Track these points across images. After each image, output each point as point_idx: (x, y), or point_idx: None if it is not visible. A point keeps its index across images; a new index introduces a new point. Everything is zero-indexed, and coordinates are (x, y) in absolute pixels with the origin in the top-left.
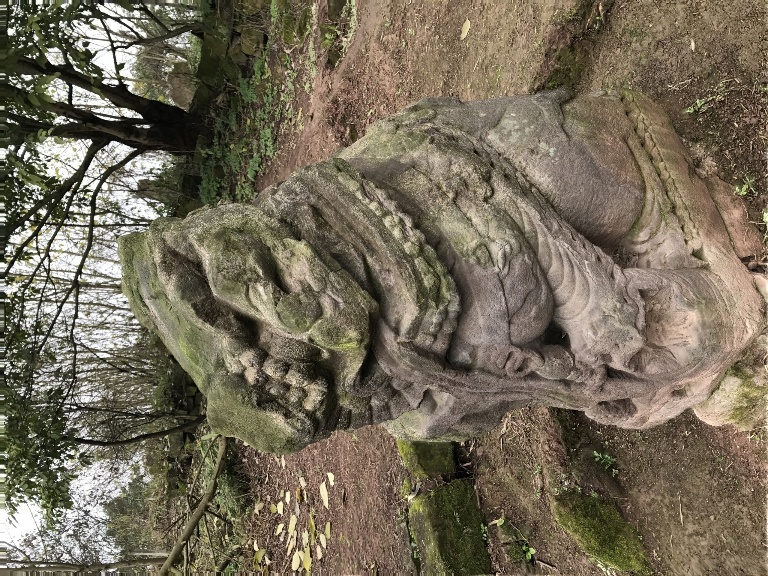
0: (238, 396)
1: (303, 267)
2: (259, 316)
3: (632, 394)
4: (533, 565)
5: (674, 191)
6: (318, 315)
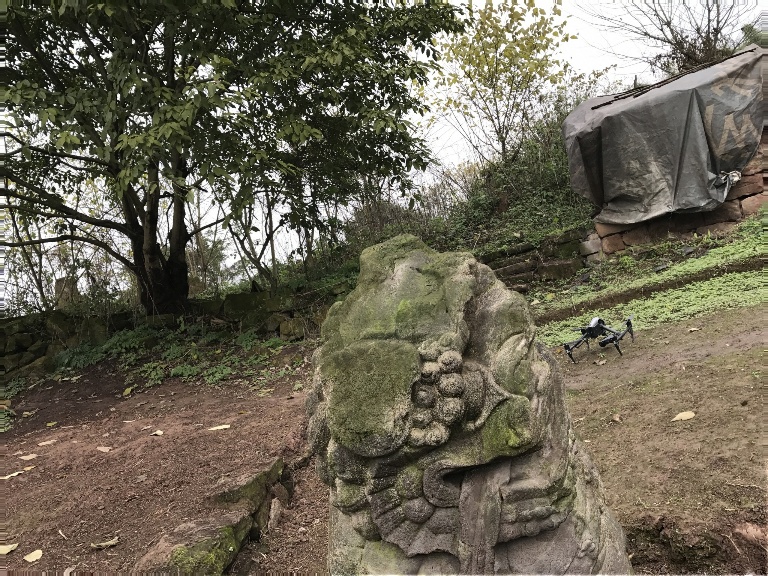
0: (414, 363)
1: (544, 371)
2: (491, 353)
3: None
4: None
5: None
6: (529, 397)
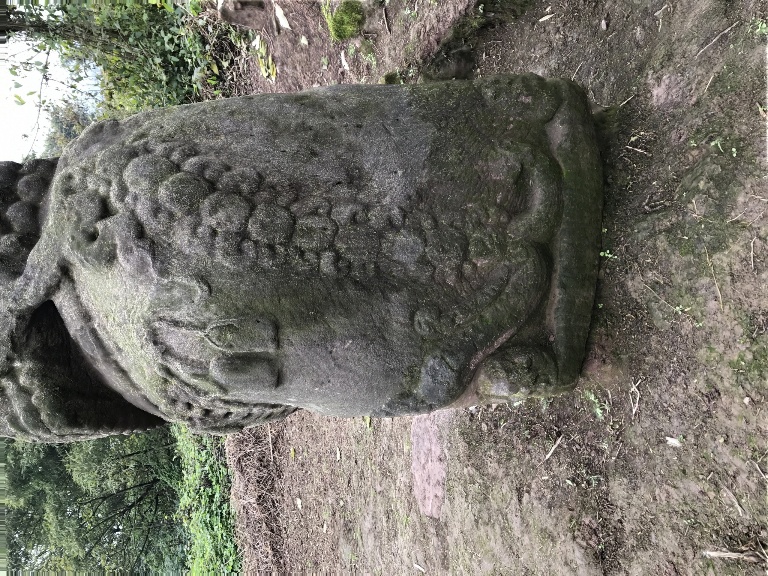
0: None
1: None
2: None
3: None
4: (380, 5)
5: None
6: None
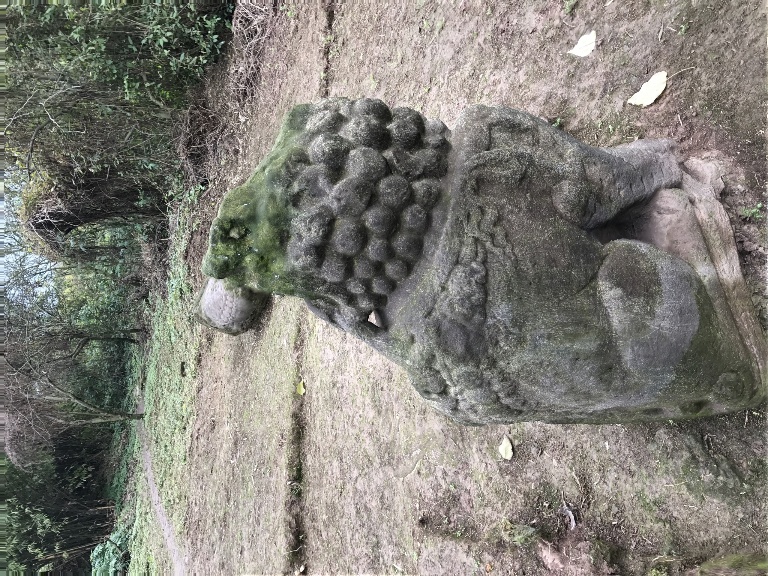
0: None
1: None
2: None
3: None
4: None
5: None
6: None
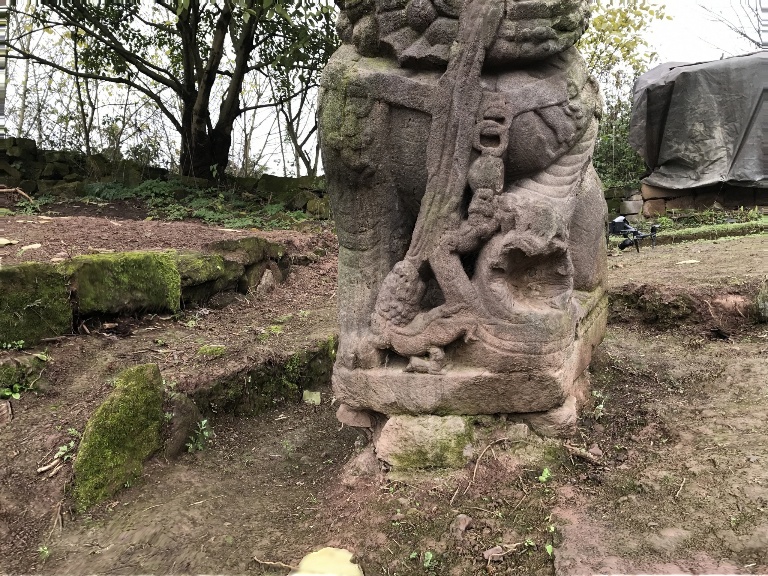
0: None
1: None
2: None
3: (454, 285)
4: None
5: (590, 321)
6: None
